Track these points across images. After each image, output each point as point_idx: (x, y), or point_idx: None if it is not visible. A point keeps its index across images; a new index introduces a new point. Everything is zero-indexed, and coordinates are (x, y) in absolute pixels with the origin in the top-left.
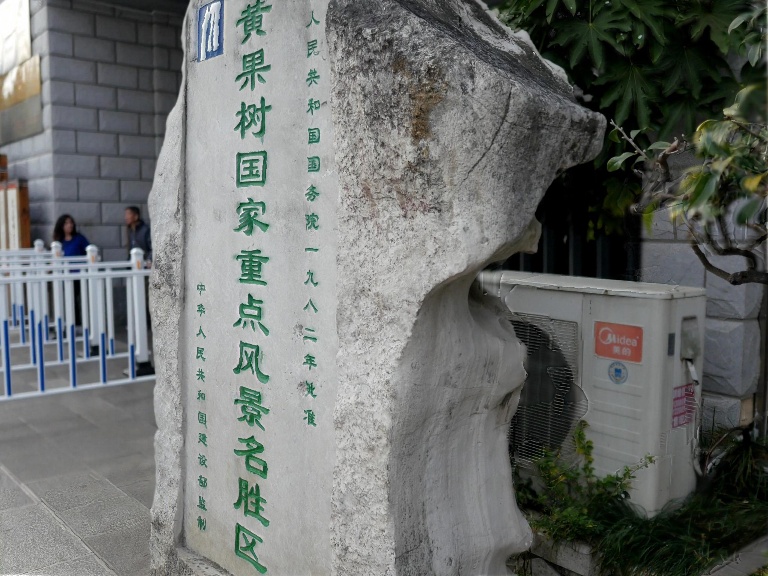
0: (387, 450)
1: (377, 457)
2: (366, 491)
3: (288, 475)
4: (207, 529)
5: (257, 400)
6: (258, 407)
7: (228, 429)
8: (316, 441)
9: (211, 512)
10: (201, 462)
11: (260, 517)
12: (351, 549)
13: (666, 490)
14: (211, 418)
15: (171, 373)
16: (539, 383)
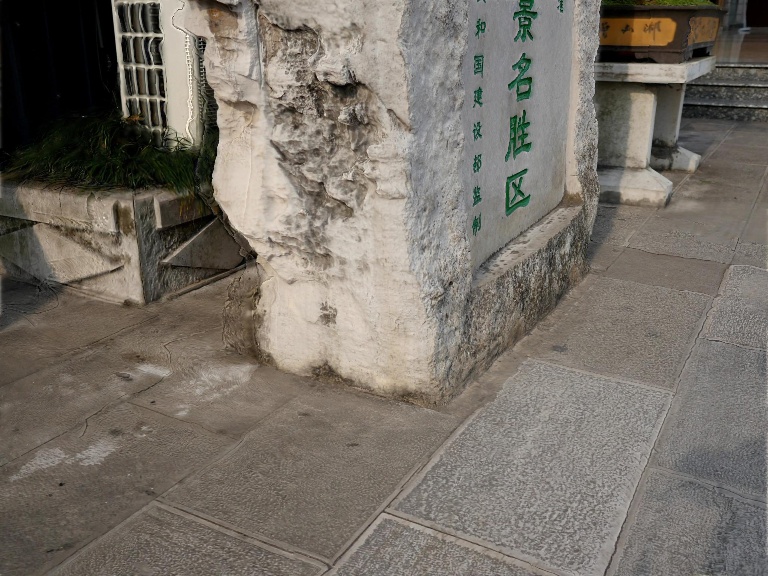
0: None
1: None
2: None
3: None
4: (483, 224)
5: (529, 5)
6: None
7: (505, 61)
8: None
9: None
10: None
11: None
12: None
13: None
14: None
15: (455, 1)
16: (16, 76)
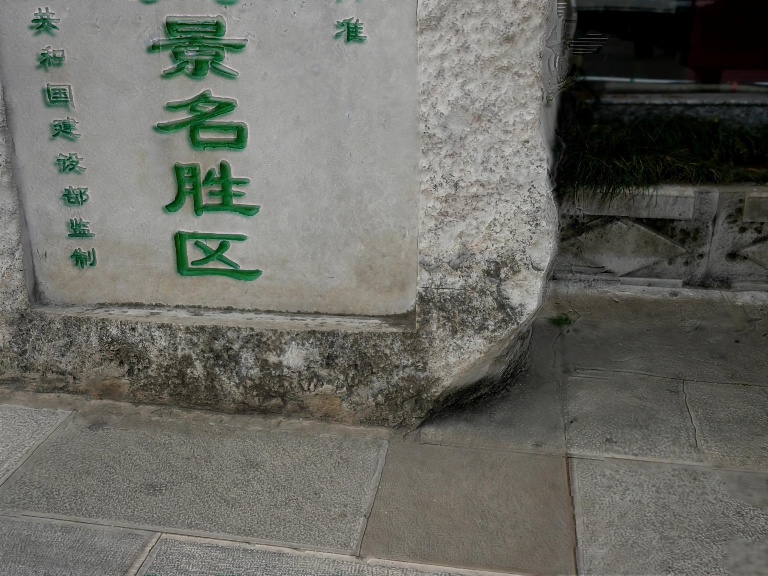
0: (540, 31)
1: (520, 46)
2: (493, 99)
3: (301, 128)
4: (102, 262)
5: (213, 31)
6: (217, 41)
7: (137, 95)
8: (367, 61)
9: (108, 234)
10: (68, 165)
11: (235, 207)
12: (463, 183)
13: (561, 114)
14: (87, 87)
15: None
16: None
